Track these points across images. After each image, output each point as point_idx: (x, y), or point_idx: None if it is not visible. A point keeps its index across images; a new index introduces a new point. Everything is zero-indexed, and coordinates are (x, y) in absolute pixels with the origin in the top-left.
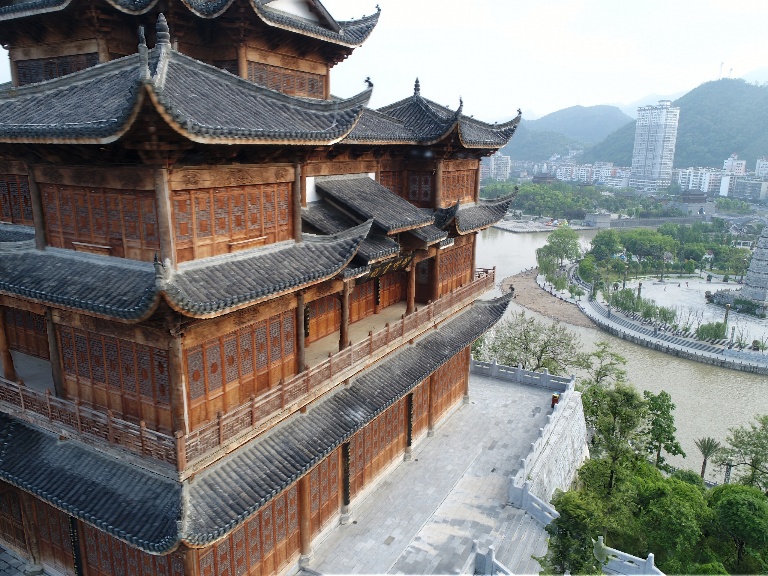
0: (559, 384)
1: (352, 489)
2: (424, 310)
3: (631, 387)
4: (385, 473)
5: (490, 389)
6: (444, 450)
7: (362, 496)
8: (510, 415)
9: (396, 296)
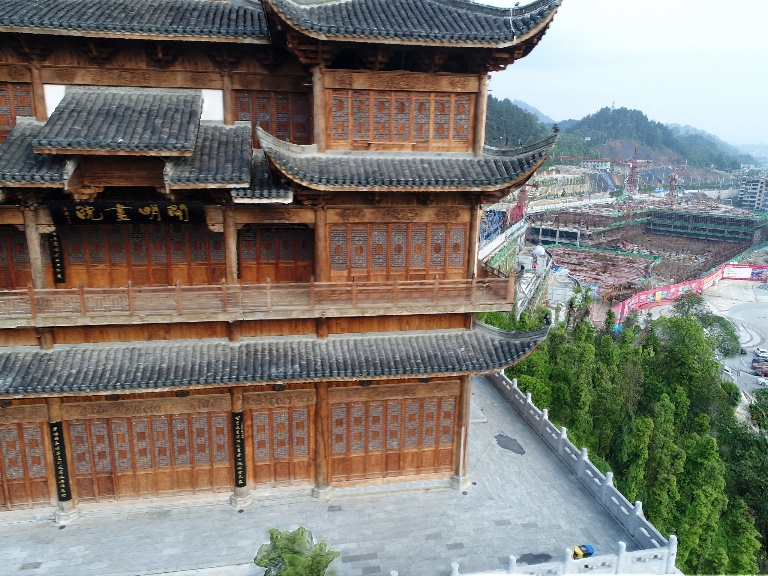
0: (649, 542)
1: (88, 489)
2: (206, 290)
3: (322, 556)
4: (177, 500)
5: (533, 490)
6: (288, 520)
7: (114, 507)
8: (476, 538)
9: (300, 278)
